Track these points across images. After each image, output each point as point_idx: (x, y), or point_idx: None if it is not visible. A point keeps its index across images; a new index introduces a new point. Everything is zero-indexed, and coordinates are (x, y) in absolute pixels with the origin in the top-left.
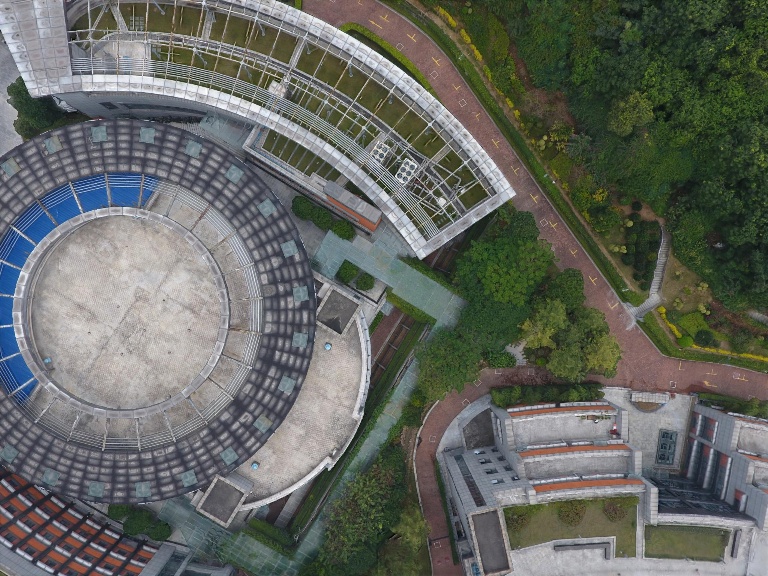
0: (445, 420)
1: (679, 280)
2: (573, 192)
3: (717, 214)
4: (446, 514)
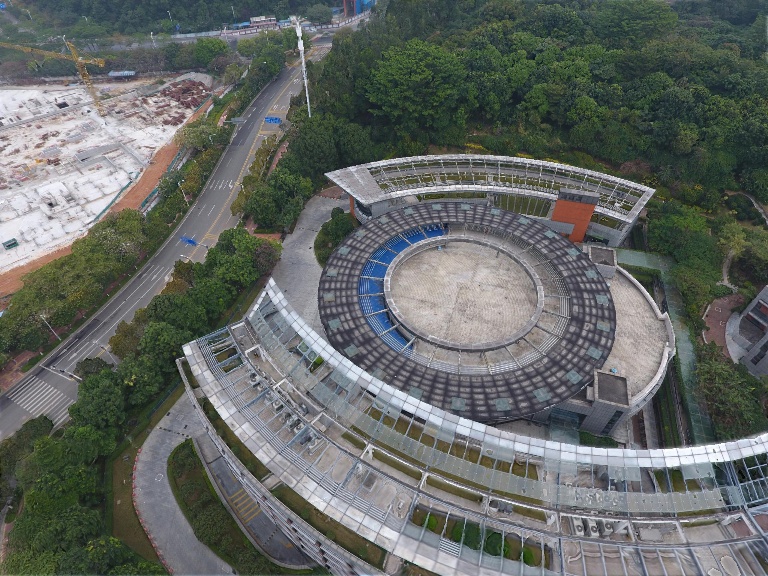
0: (719, 340)
1: None
2: (681, 194)
3: None
4: None
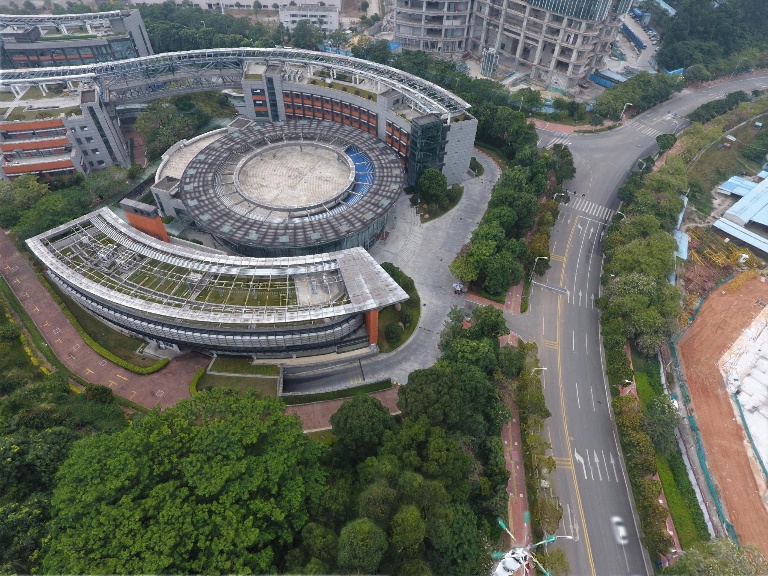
0: None
1: None
2: None
3: None
4: None
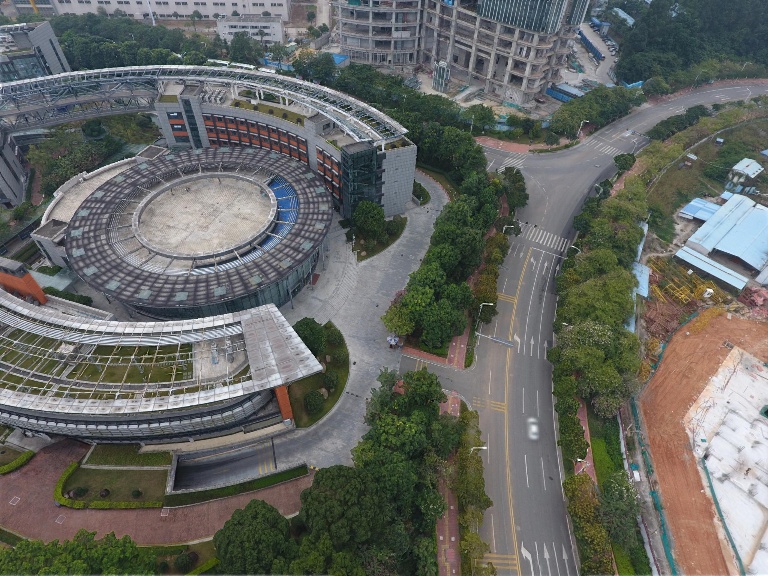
0: None
1: None
2: None
3: None
4: (31, 184)
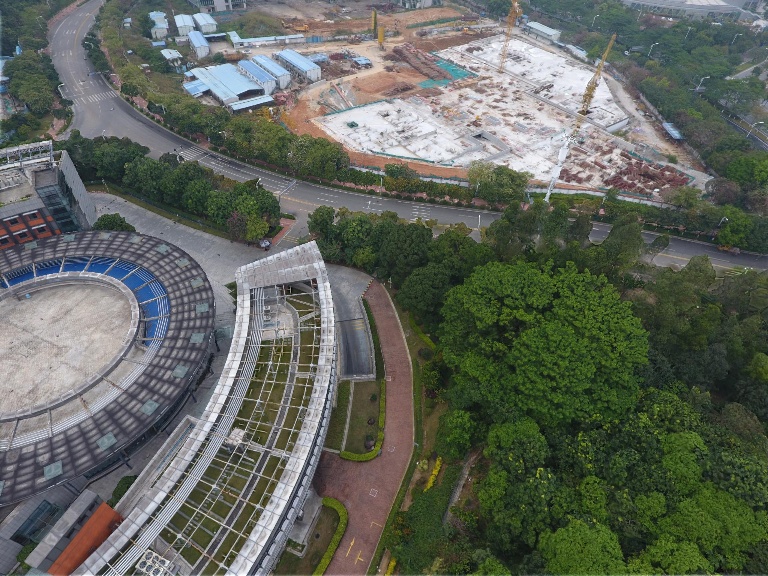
0: None
1: None
2: None
3: None
4: None
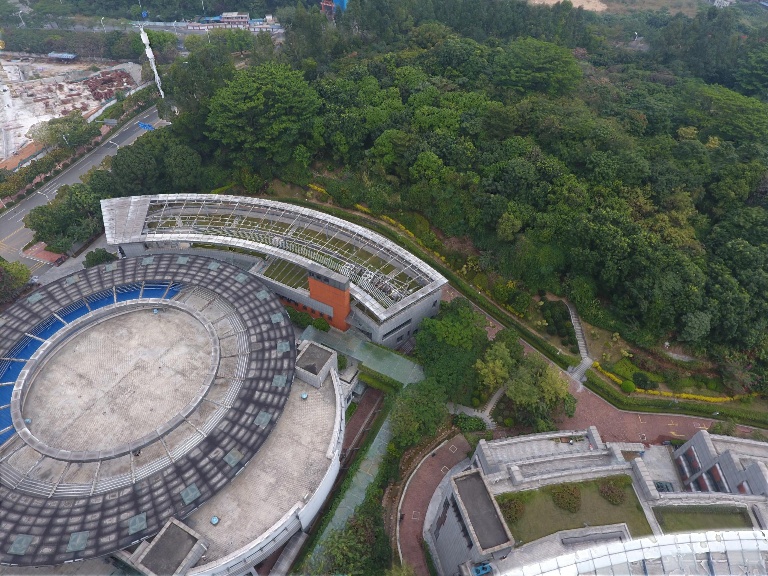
0: (427, 492)
1: (598, 339)
2: (493, 288)
3: (588, 268)
4: None
